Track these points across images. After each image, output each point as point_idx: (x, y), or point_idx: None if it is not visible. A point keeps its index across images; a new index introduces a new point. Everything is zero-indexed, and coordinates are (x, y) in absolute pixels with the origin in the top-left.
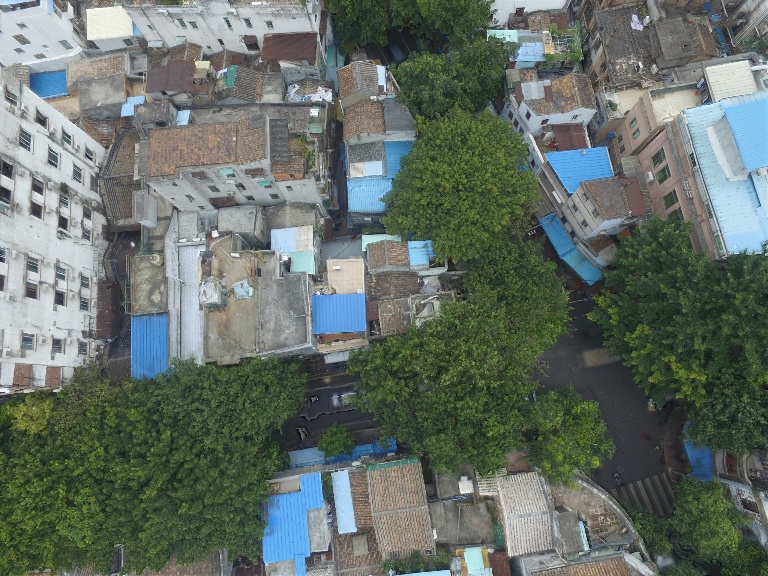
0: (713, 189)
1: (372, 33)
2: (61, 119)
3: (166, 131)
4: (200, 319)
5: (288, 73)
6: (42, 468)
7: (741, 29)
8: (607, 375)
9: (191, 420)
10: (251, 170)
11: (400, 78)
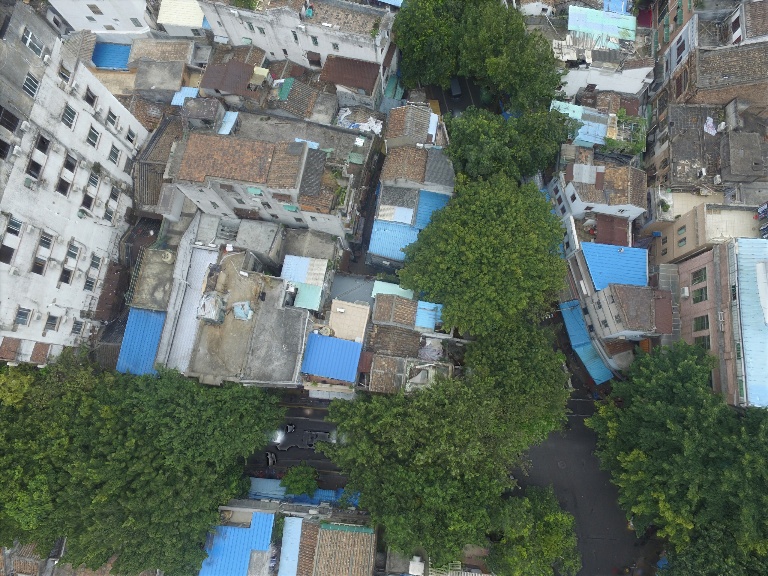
0: (748, 330)
1: (436, 75)
2: (110, 99)
3: (206, 137)
4: (196, 325)
5: (343, 97)
6: (6, 444)
7: None
8: (593, 479)
9: (159, 431)
10: (279, 195)
11: (452, 129)
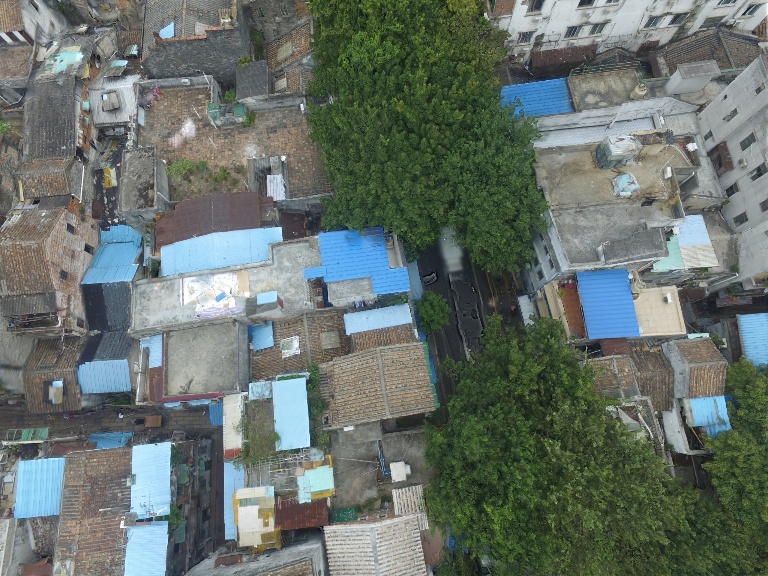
0: None
1: None
2: None
3: None
4: None
5: None
6: (417, 8)
7: None
8: None
9: None
10: None
11: None
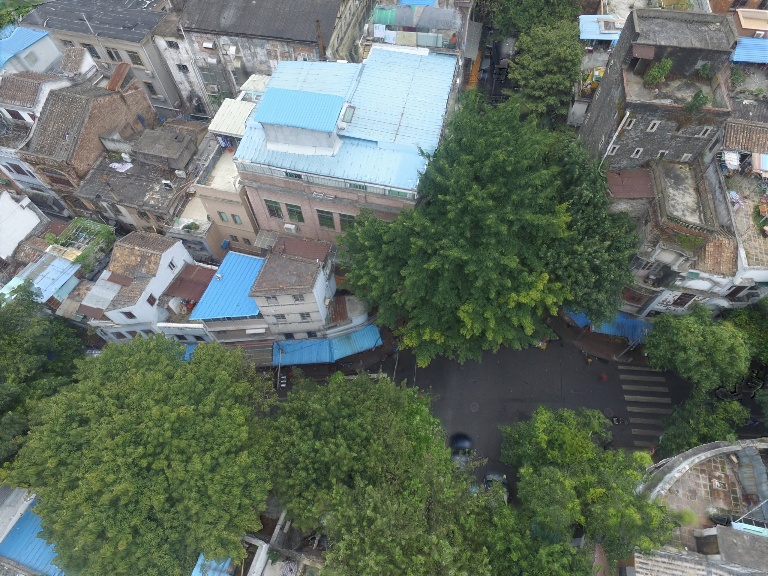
0: (336, 172)
1: None
2: None
3: None
4: None
5: None
6: None
7: (202, 105)
8: (492, 375)
9: None
10: None
11: None
